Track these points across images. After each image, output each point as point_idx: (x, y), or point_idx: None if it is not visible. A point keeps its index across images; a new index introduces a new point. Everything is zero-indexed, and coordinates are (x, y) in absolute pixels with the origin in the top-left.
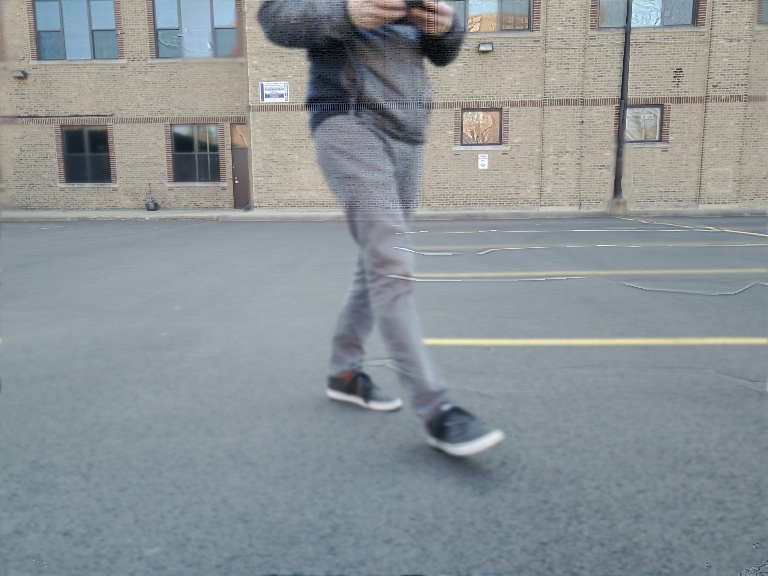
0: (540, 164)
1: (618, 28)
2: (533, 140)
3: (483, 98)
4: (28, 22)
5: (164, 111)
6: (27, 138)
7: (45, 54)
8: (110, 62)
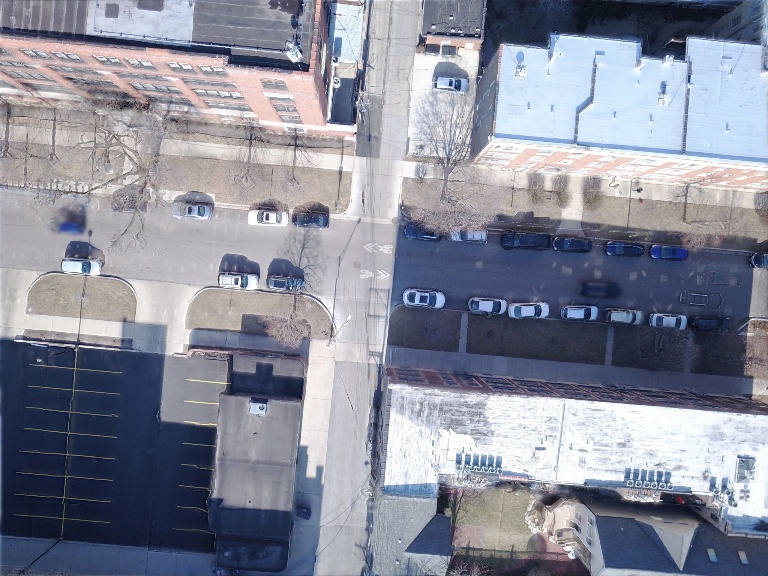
0: None
1: None
2: None
3: None
4: None
5: None
6: None
7: None
8: None
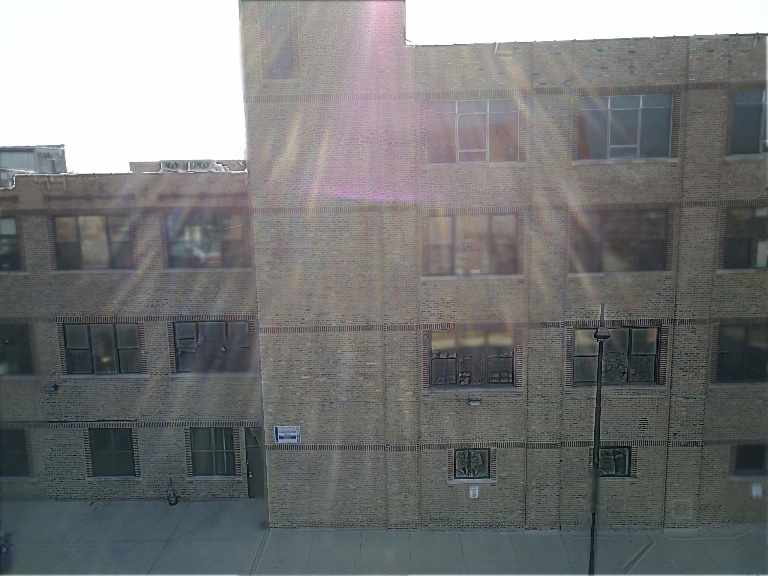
0: (524, 495)
1: (590, 384)
2: (518, 474)
3: (473, 440)
4: (59, 342)
5: (184, 417)
6: (57, 439)
7: (74, 368)
8: (134, 376)
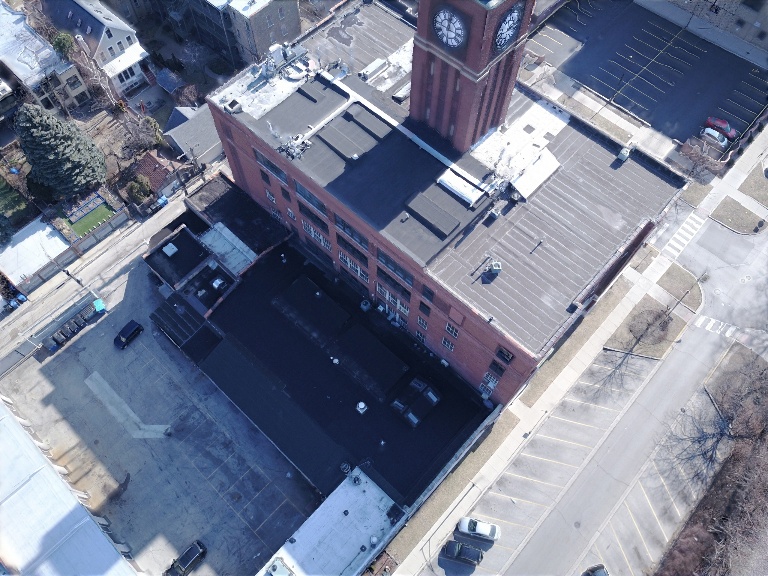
0: None
1: None
2: (696, 3)
3: None
4: None
5: None
6: None
7: None
8: None
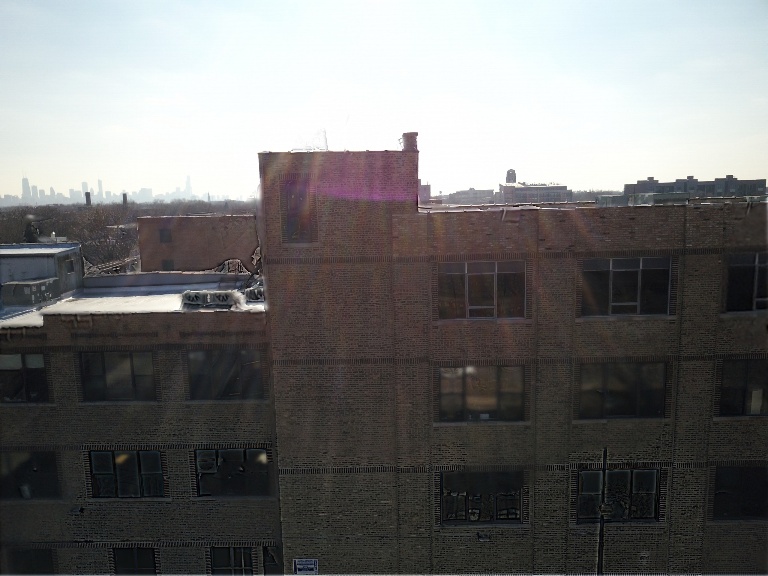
0: None
1: (594, 521)
2: None
3: (482, 572)
4: (85, 468)
5: (204, 537)
6: (83, 558)
7: (99, 492)
8: (157, 500)
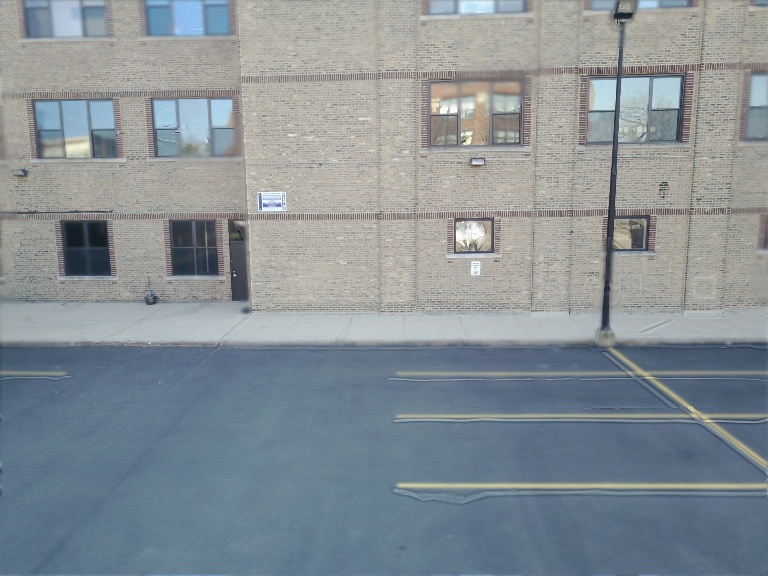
0: (531, 271)
1: (605, 143)
2: (524, 248)
3: (475, 208)
4: (28, 122)
5: (163, 207)
6: (27, 233)
7: (45, 152)
8: (109, 161)
